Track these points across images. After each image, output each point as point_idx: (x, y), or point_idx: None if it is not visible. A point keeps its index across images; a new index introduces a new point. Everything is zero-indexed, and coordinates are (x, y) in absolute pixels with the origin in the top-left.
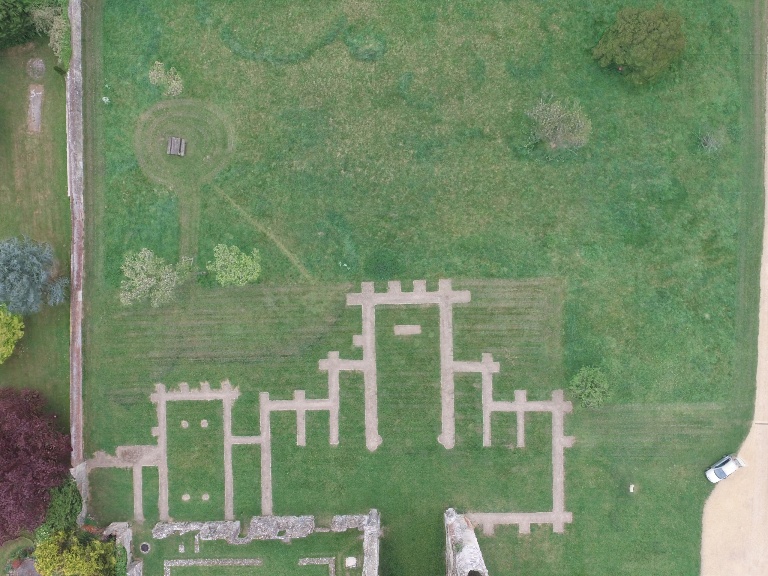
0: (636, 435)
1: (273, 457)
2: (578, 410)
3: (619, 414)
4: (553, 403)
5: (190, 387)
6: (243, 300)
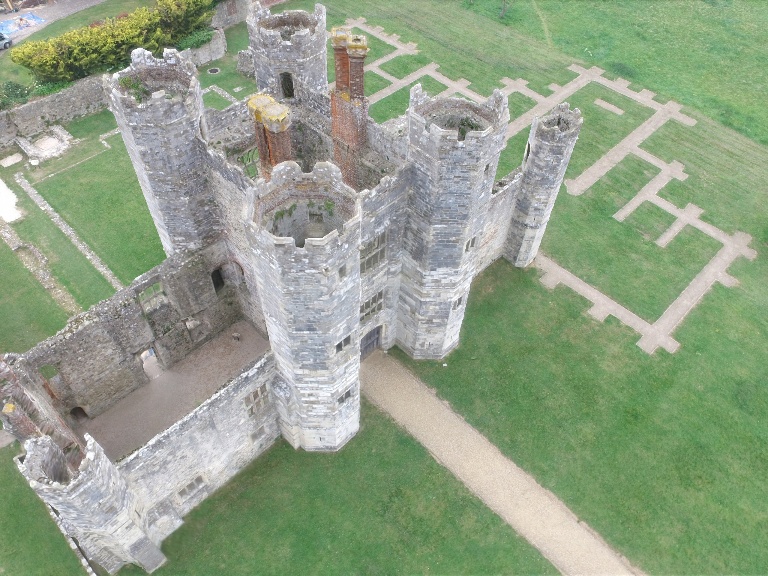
0: None
1: (393, 95)
2: (762, 263)
3: None
4: (731, 239)
5: (384, 31)
6: (483, 24)
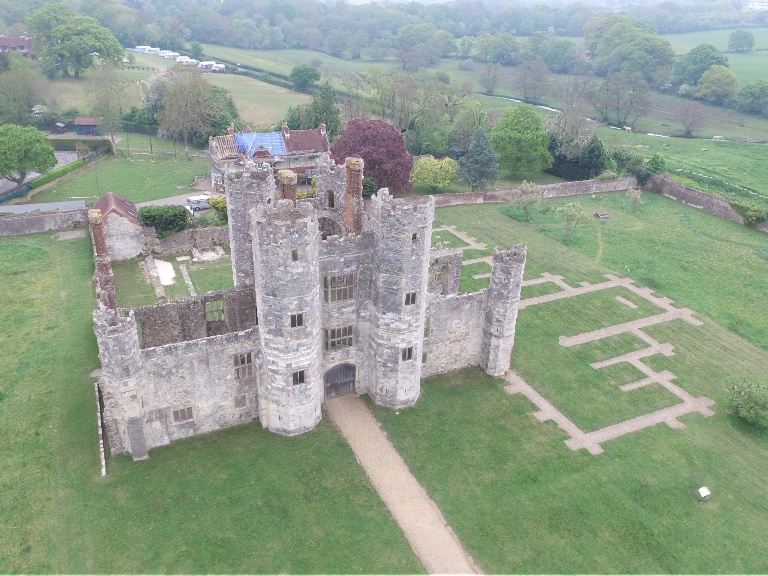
0: (765, 482)
1: None
2: (715, 420)
3: (762, 457)
4: (694, 400)
5: (466, 234)
6: (547, 242)
